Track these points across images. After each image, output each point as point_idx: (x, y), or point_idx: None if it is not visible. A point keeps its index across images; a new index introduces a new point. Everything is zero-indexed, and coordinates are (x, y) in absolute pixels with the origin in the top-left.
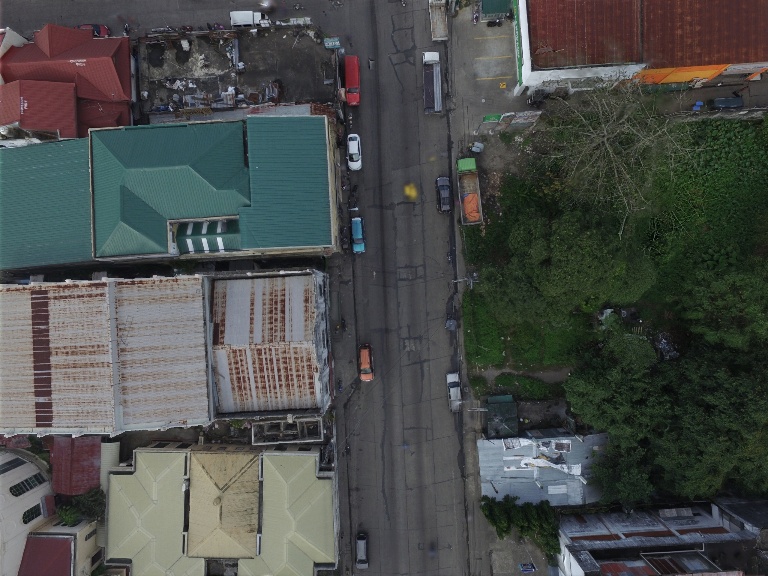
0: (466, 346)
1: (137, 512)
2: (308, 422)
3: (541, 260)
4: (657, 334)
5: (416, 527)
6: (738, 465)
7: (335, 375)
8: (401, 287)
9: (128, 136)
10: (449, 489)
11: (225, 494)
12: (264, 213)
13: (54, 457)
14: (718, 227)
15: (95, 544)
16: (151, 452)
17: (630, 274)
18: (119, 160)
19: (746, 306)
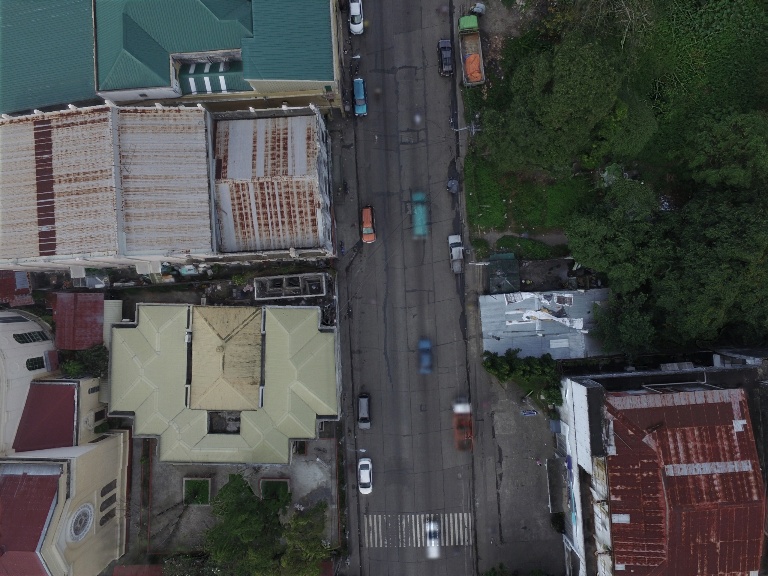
0: (468, 209)
1: (140, 362)
2: (310, 281)
3: (543, 88)
4: (659, 197)
5: (418, 389)
6: (740, 301)
7: (337, 236)
8: (403, 151)
9: None
10: (451, 351)
11: (228, 344)
12: (266, 45)
13: (57, 314)
14: (720, 89)
15: (98, 401)
16: (154, 305)
17: (632, 120)
18: None
19: (748, 141)
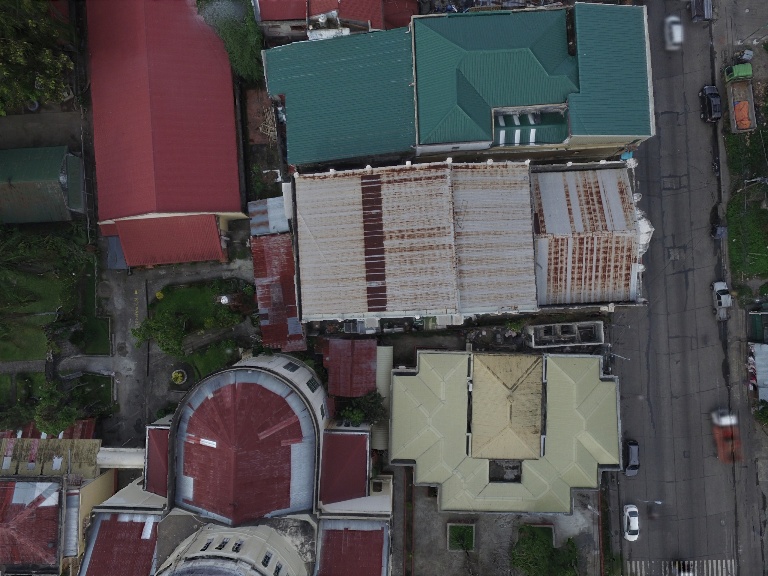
0: (732, 255)
1: (427, 411)
2: (581, 328)
3: None
4: None
5: (681, 435)
6: None
7: None
8: (665, 196)
9: (454, 23)
10: (714, 398)
11: (514, 394)
12: (591, 100)
13: (330, 360)
14: None
15: None
16: (434, 353)
17: None
18: (455, 43)
19: None
